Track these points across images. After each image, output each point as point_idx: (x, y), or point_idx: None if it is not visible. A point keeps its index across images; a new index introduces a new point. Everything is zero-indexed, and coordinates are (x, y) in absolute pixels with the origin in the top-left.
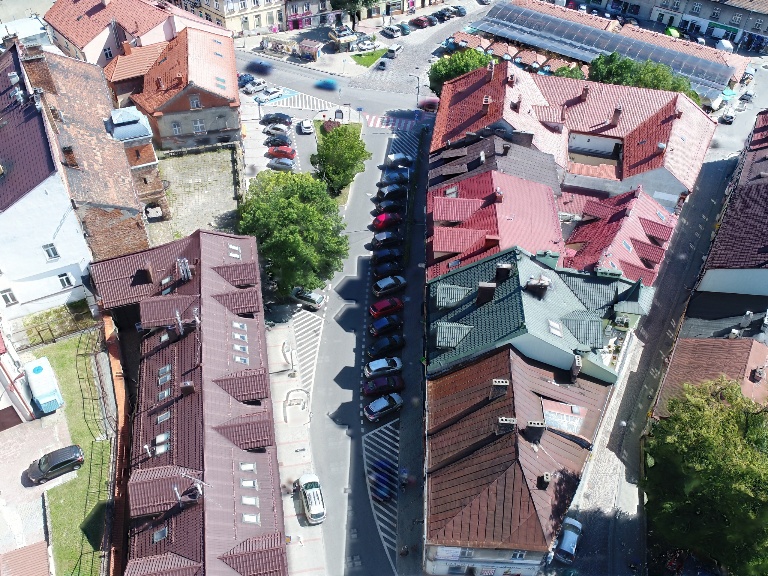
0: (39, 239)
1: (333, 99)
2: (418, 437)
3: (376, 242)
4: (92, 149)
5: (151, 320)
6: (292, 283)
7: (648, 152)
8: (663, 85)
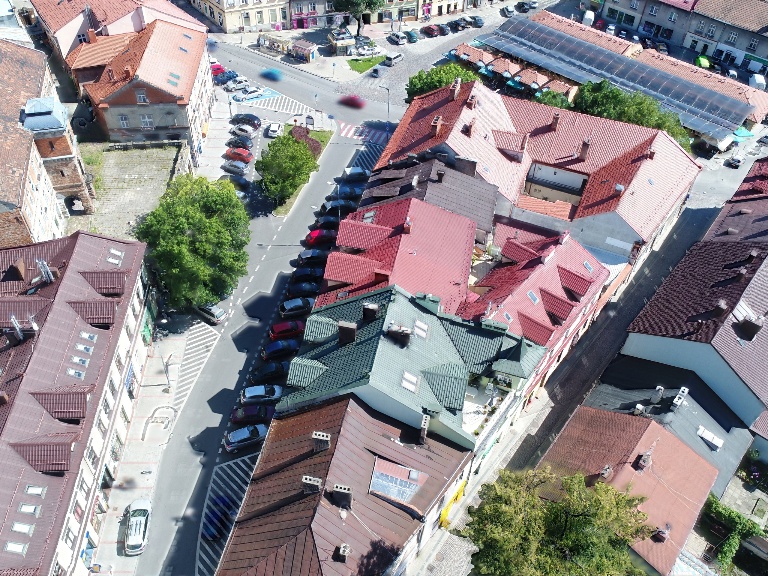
0: None
1: (313, 104)
2: None
3: (300, 259)
4: None
5: (0, 320)
6: (178, 295)
7: (607, 193)
8: (647, 120)
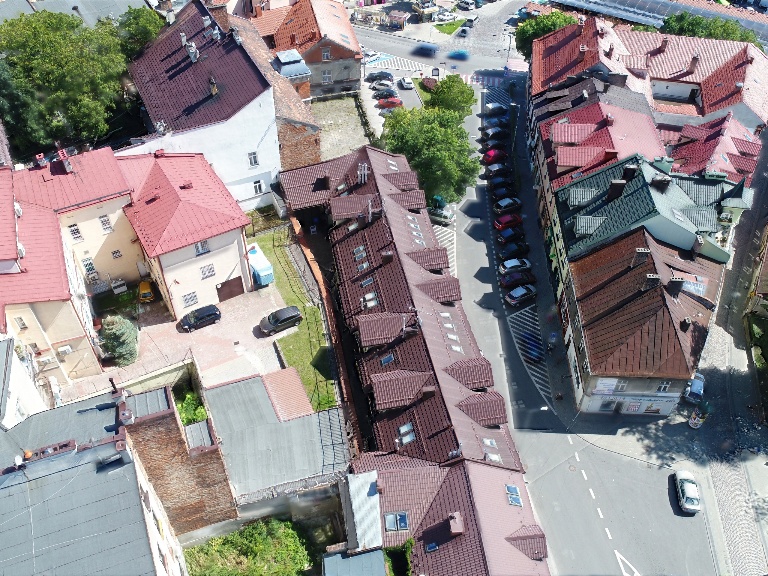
0: (247, 147)
1: (425, 61)
2: (554, 317)
3: (490, 172)
4: (270, 81)
5: (340, 213)
6: (437, 195)
7: (726, 92)
8: (732, 38)
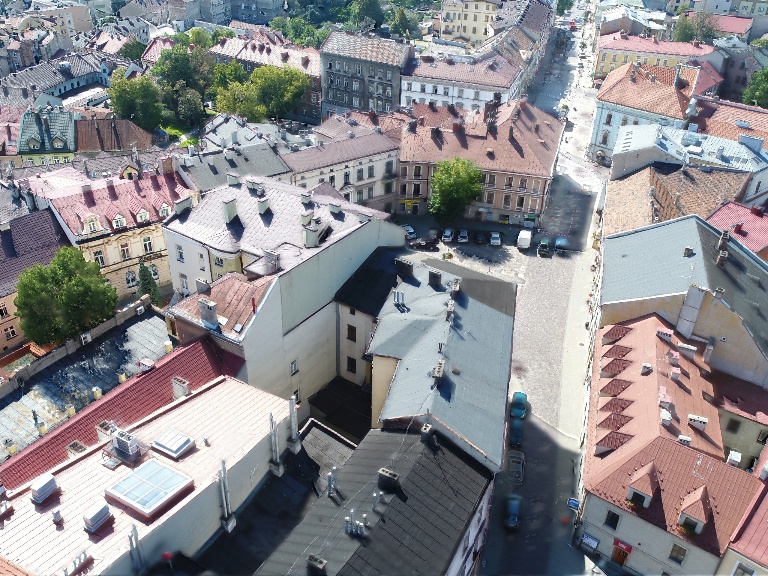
0: None
1: None
2: None
3: None
4: None
5: None
6: None
7: None
8: None
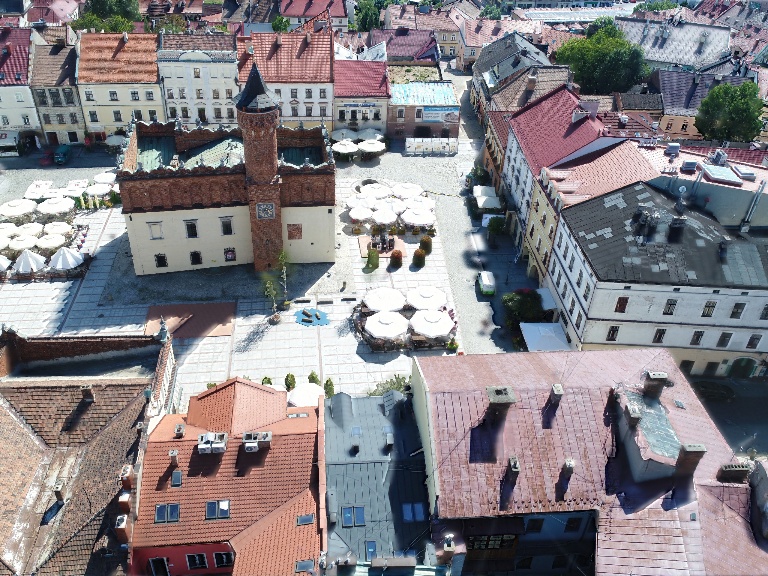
0: None
1: None
2: None
3: None
4: None
5: None
6: None
7: None
8: None
